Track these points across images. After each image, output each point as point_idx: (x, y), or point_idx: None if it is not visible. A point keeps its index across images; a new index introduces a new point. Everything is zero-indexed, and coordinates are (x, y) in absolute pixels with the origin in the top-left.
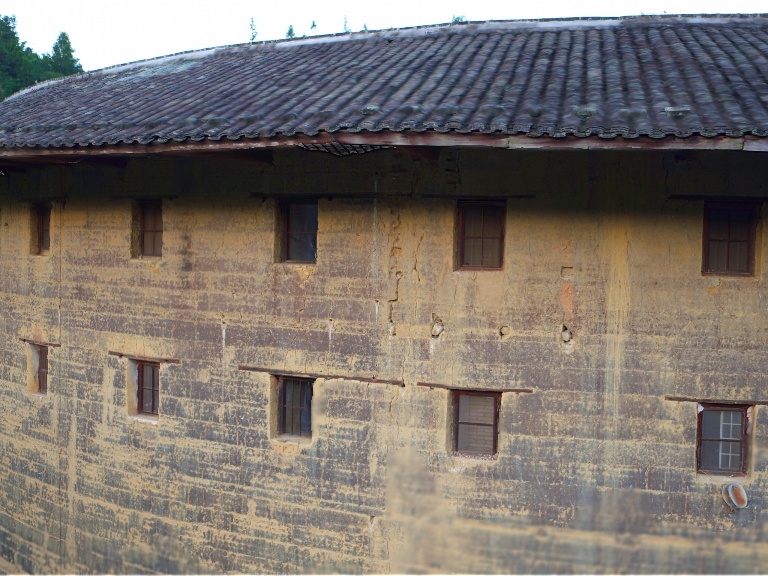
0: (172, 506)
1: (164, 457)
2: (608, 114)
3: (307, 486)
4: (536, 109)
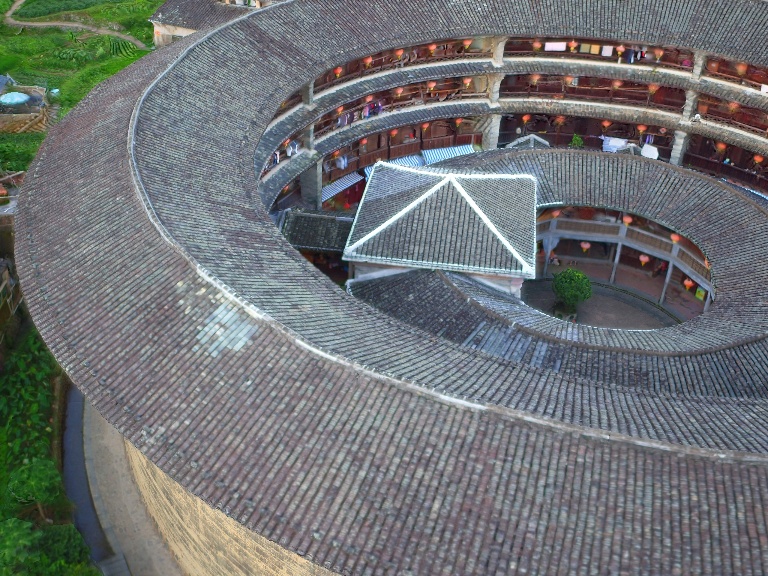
0: (248, 547)
1: (243, 527)
2: (420, 574)
3: (309, 575)
4: (386, 567)
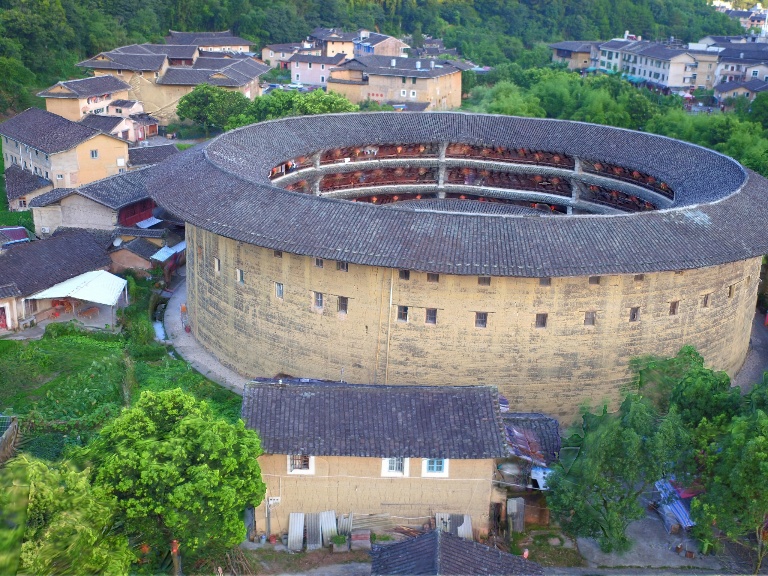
0: None
1: None
2: None
3: None
4: None
